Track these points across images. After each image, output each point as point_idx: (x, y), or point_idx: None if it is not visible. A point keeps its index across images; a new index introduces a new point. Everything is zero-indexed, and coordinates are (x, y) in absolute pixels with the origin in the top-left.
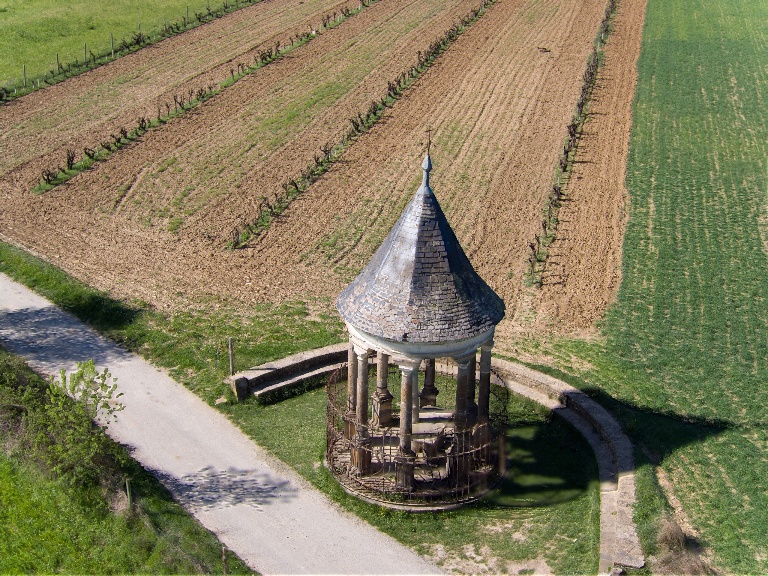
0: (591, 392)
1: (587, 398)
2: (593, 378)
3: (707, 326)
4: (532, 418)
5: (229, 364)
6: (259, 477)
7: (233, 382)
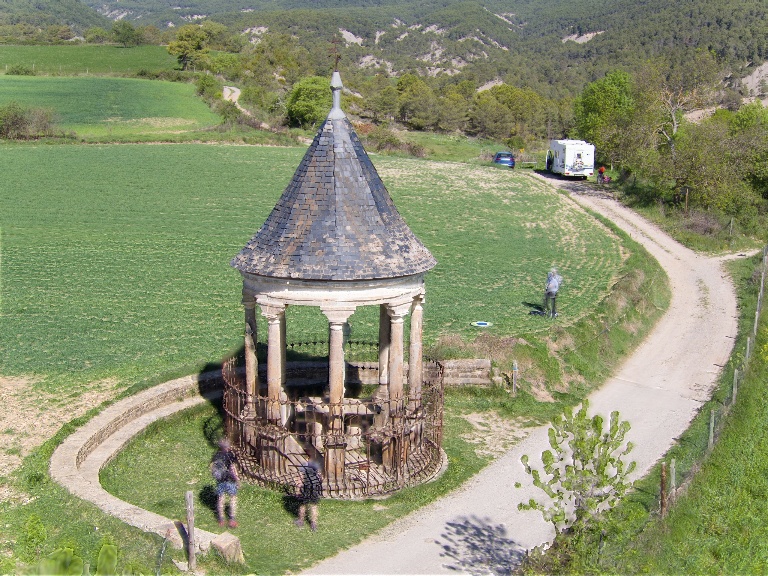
0: (198, 368)
1: (204, 374)
2: (144, 377)
3: (3, 337)
4: (209, 419)
5: (145, 573)
6: (435, 534)
7: (238, 543)
